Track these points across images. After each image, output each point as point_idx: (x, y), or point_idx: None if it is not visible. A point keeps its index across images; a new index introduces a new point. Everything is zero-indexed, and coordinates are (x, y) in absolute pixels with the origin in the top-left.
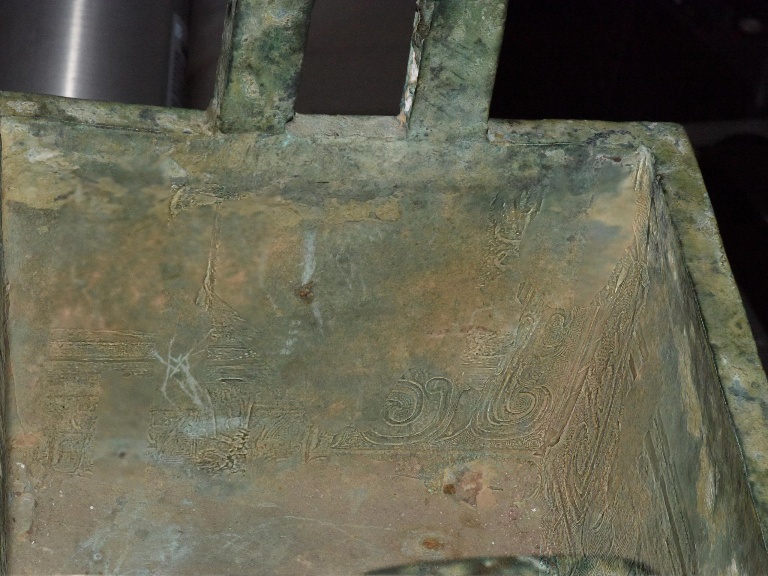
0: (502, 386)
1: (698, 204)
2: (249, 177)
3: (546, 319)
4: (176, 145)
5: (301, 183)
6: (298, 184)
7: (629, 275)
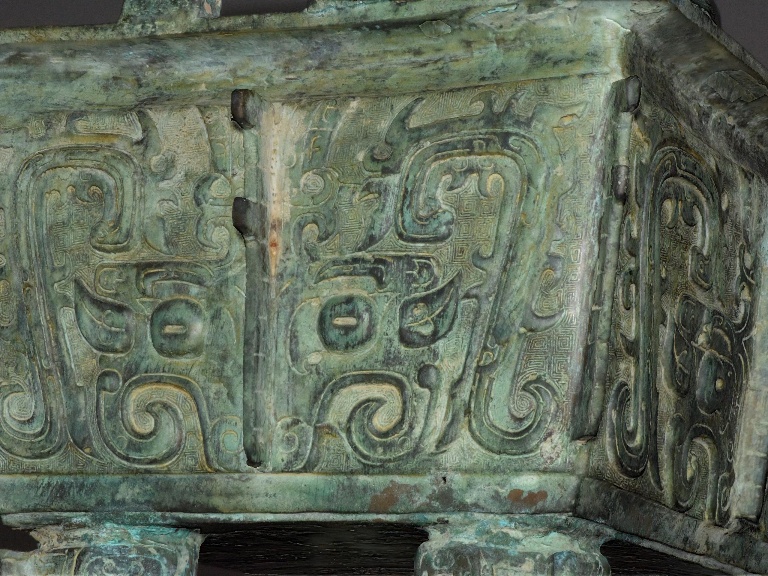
0: None
1: None
2: (367, 70)
3: (14, 288)
4: (447, 25)
5: (314, 79)
6: (317, 80)
7: None
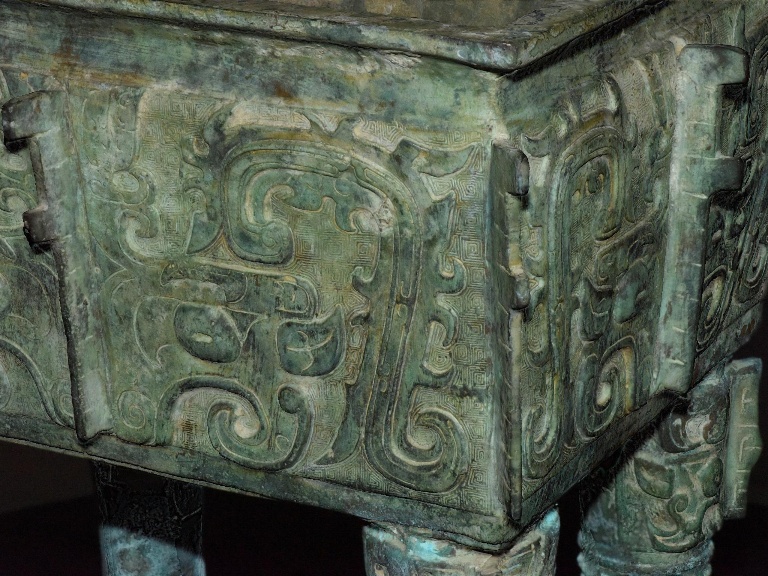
0: (557, 396)
1: (376, 22)
2: None
3: None
4: None
5: None
6: None
7: (478, 224)
